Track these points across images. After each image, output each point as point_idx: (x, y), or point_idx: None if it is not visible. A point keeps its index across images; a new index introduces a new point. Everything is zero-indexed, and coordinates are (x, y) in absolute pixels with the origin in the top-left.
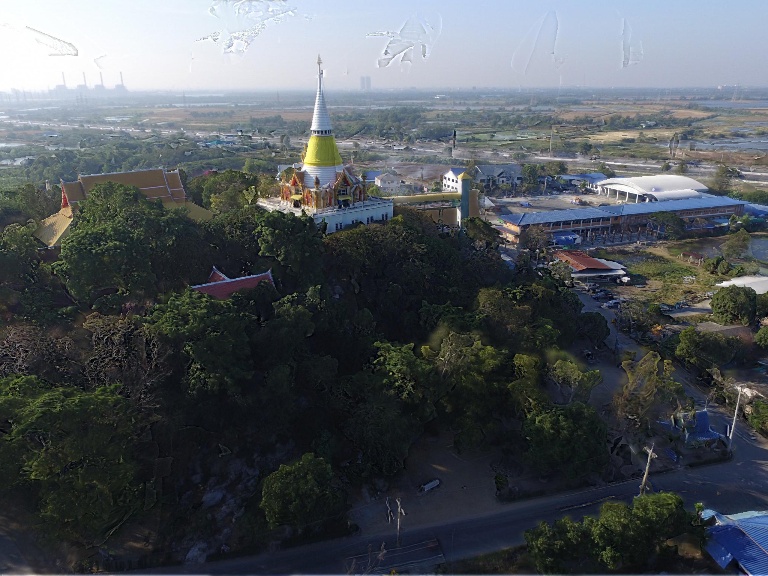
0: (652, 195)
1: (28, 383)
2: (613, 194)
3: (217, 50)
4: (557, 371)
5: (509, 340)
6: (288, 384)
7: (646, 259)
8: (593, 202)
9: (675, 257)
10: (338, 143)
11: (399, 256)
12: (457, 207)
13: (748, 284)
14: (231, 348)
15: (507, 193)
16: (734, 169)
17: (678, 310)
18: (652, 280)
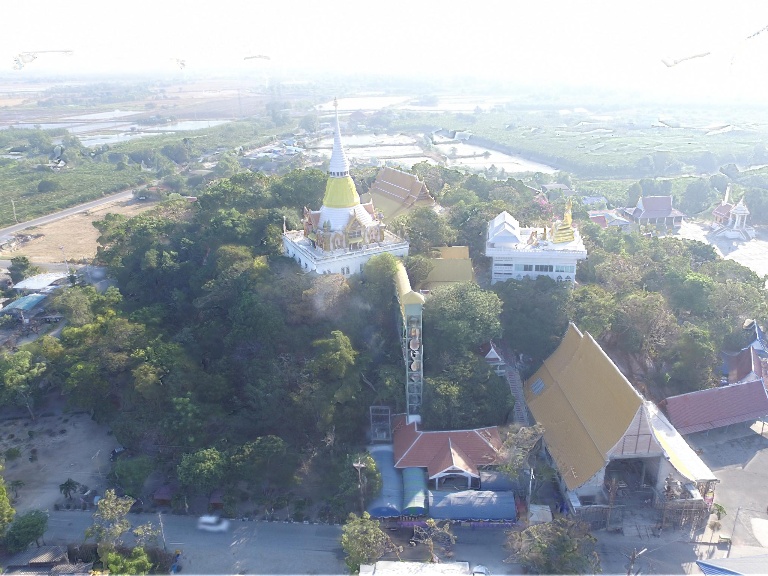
0: None
1: (134, 220)
2: None
3: (767, 51)
4: (23, 351)
5: None
6: (120, 276)
7: None
8: None
9: None
10: None
11: None
12: None
13: None
14: (127, 246)
15: None
16: None
17: None
18: None
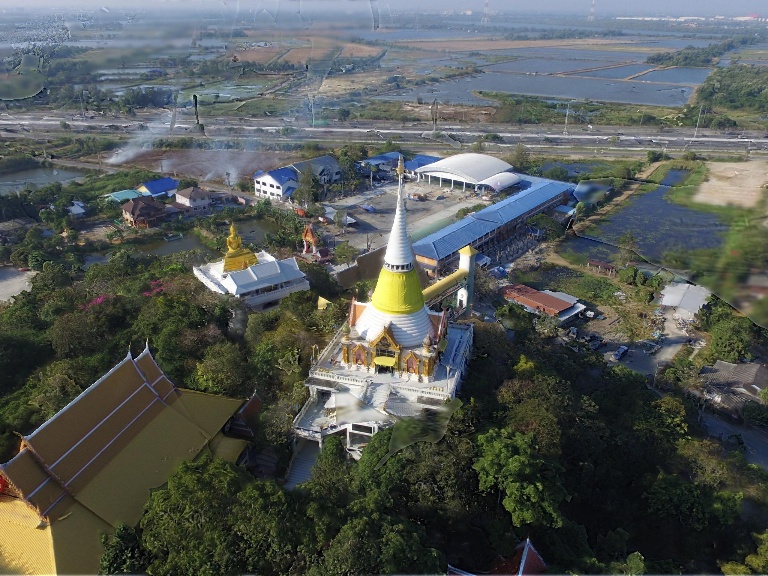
0: (489, 186)
1: None
2: (433, 180)
3: None
4: None
5: (766, 510)
6: None
7: (559, 274)
8: (426, 194)
9: (577, 266)
10: (32, 123)
11: (565, 420)
12: (464, 286)
13: (684, 298)
14: None
15: (337, 194)
16: (497, 135)
17: (665, 345)
18: (600, 306)
